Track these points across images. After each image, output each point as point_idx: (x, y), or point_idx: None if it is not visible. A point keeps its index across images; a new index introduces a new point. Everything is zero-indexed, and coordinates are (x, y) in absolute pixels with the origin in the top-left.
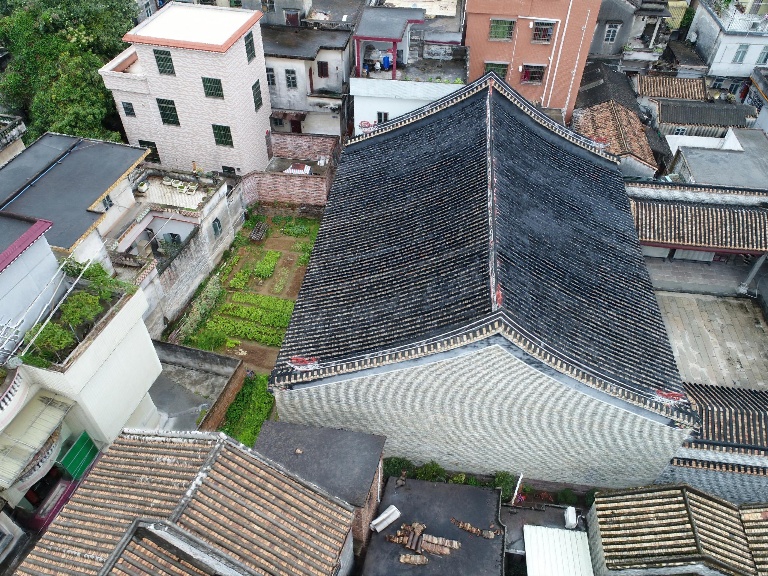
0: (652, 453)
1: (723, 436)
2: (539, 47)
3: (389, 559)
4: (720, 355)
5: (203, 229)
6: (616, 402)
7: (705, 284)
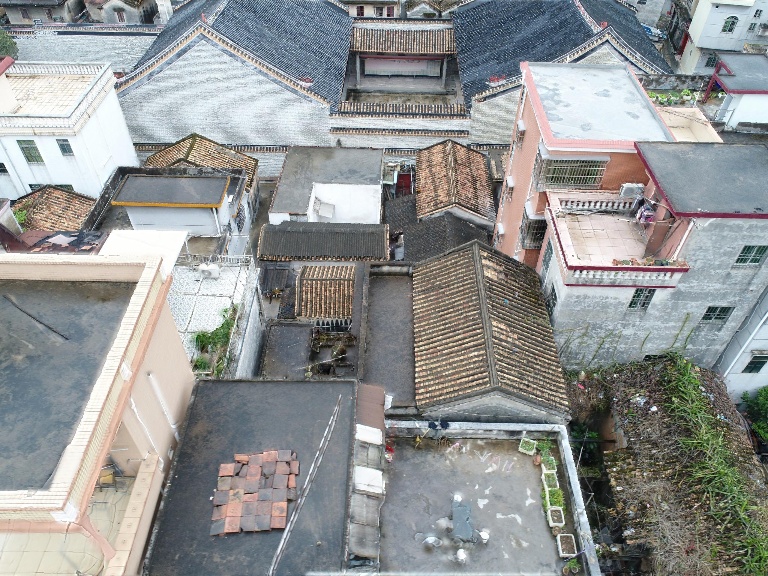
0: None
1: None
2: None
3: None
4: None
5: None
6: None
7: None
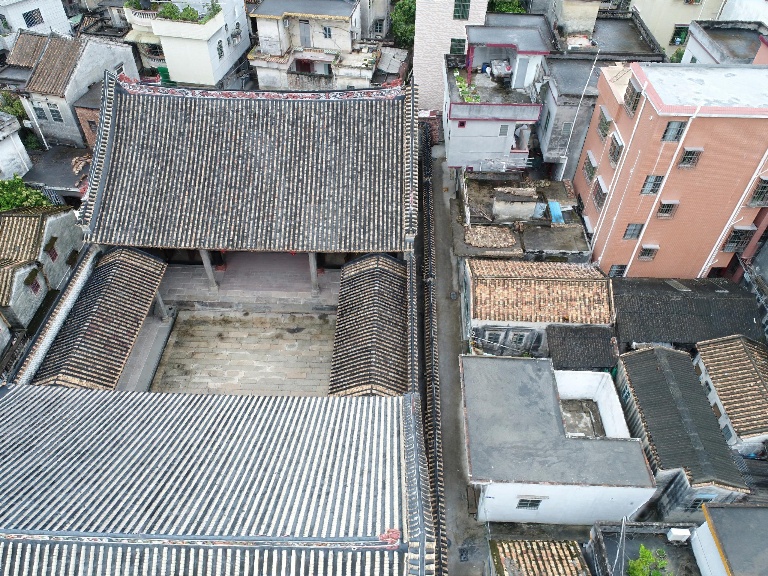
0: None
1: None
2: (611, 167)
3: (80, 155)
4: None
5: (338, 82)
6: None
7: None
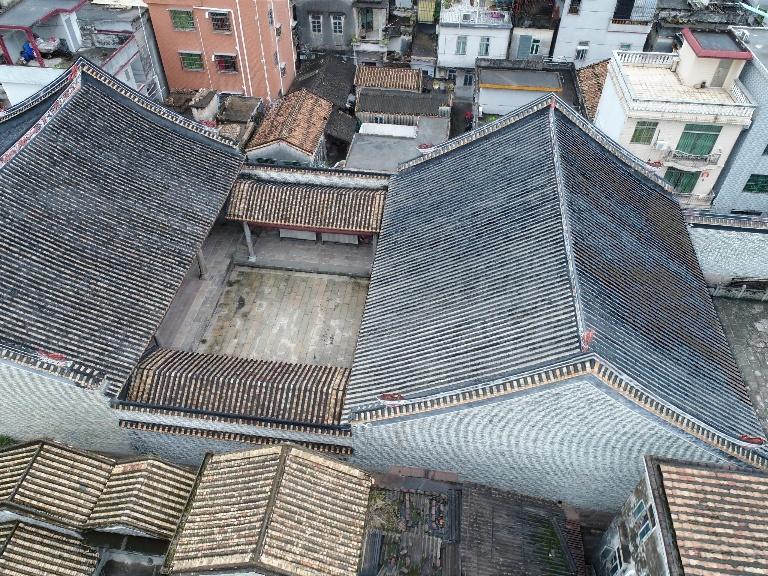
0: (99, 415)
1: (173, 400)
2: (223, 37)
3: None
4: (317, 332)
5: None
6: (11, 363)
7: (343, 265)
